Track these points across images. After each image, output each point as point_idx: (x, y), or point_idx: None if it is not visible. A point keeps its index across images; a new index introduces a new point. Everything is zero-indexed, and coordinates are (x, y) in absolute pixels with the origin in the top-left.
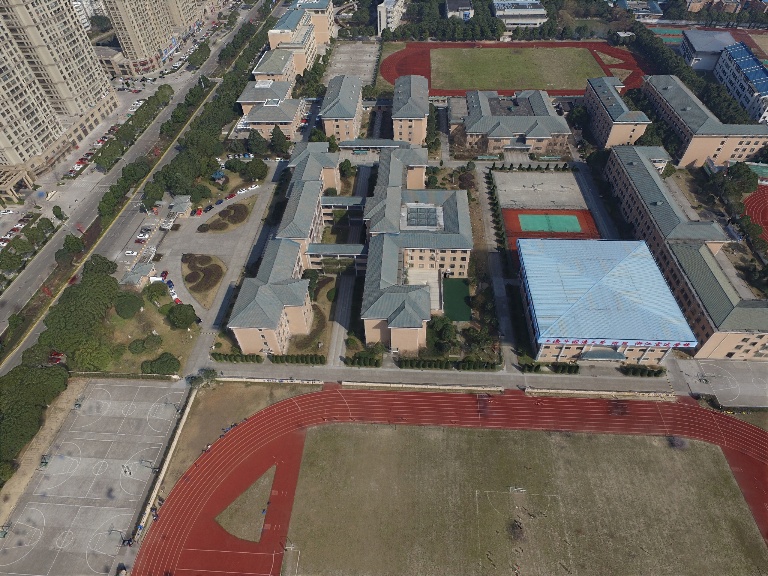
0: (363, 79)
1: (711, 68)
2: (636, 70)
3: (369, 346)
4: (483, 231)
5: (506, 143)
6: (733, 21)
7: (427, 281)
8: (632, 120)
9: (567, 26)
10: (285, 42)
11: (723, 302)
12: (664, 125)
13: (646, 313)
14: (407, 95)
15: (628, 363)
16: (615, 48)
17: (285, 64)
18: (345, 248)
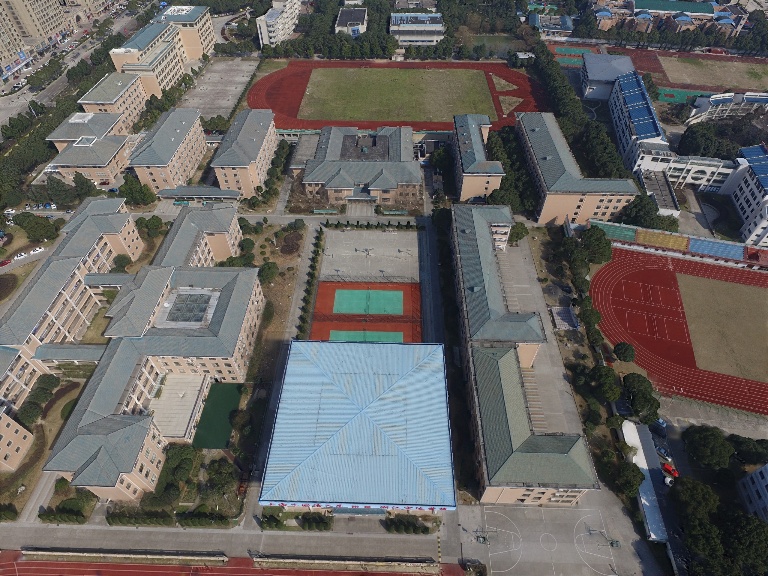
0: (224, 105)
1: (607, 98)
2: (527, 98)
3: (83, 490)
4: (287, 313)
5: (348, 194)
6: (643, 41)
7: (185, 392)
8: (484, 171)
9: (463, 45)
10: (131, 63)
11: (504, 442)
12: (523, 176)
13: (405, 460)
14: (235, 137)
15: (396, 513)
16: (513, 71)
17: (121, 91)
18: (81, 353)
